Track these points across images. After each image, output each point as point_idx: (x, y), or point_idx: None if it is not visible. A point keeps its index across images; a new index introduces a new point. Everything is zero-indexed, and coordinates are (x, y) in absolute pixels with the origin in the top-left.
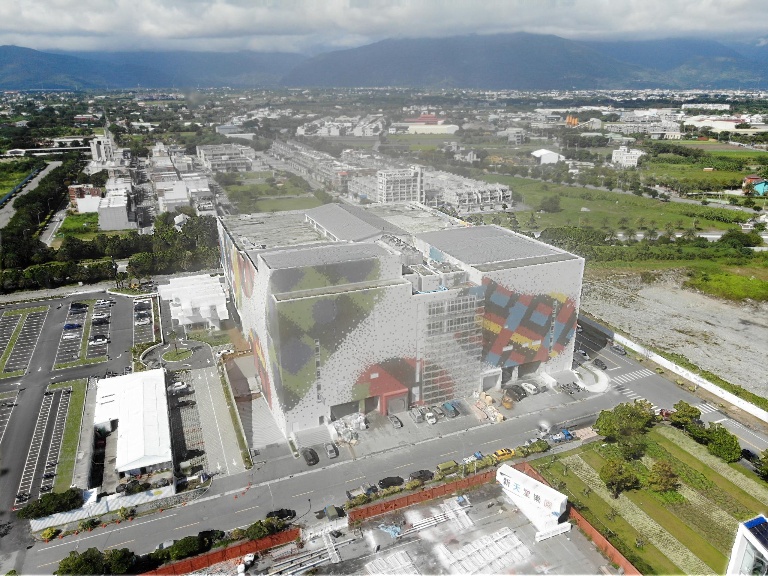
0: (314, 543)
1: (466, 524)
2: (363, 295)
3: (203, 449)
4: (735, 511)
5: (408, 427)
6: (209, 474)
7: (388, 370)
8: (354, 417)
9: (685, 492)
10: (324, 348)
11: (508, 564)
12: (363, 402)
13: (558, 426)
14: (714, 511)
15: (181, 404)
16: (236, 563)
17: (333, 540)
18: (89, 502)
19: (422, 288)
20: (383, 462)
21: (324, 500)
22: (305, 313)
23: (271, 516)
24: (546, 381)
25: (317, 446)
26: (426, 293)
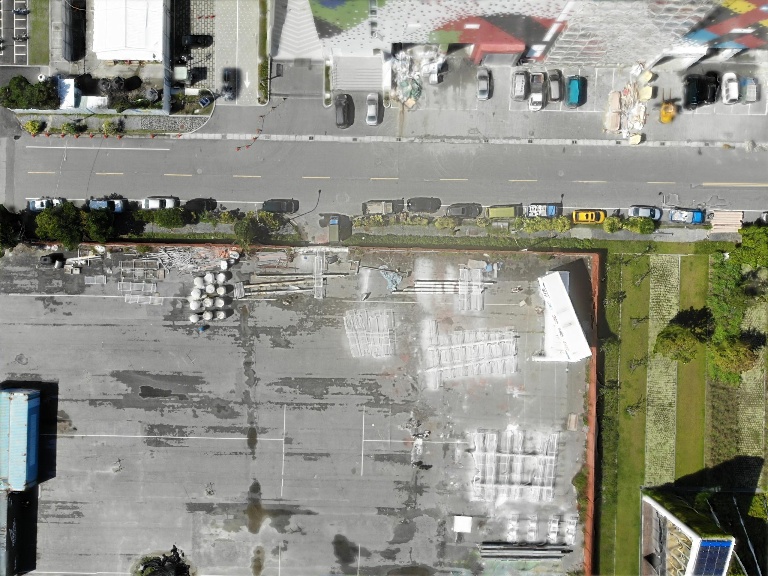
0: (305, 260)
1: (473, 305)
2: None
3: (211, 33)
4: None
5: (497, 102)
6: (212, 92)
7: (499, 23)
8: (428, 56)
9: (751, 369)
10: None
11: (484, 372)
12: (446, 45)
13: (703, 190)
14: (754, 407)
15: None
16: (221, 254)
17: (326, 265)
18: (66, 105)
19: None
20: (431, 161)
21: (336, 199)
22: None
23: (266, 210)
24: None
25: (359, 93)
26: None
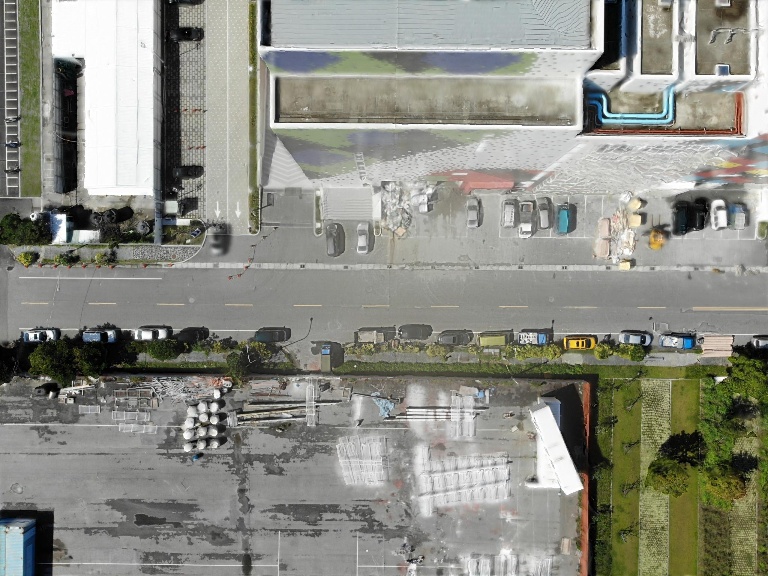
0: (298, 387)
1: (466, 431)
2: (461, 132)
3: (202, 164)
4: (767, 543)
5: (487, 230)
6: (204, 222)
7: (486, 172)
8: (417, 186)
9: None
10: (372, 157)
11: (477, 497)
12: (435, 181)
13: (693, 314)
14: (746, 530)
15: (179, 38)
16: (214, 383)
17: (318, 392)
18: (58, 240)
19: (622, 85)
20: (422, 288)
21: (328, 327)
22: (333, 137)
23: (259, 341)
24: (759, 206)
25: (349, 222)
26: (608, 137)
